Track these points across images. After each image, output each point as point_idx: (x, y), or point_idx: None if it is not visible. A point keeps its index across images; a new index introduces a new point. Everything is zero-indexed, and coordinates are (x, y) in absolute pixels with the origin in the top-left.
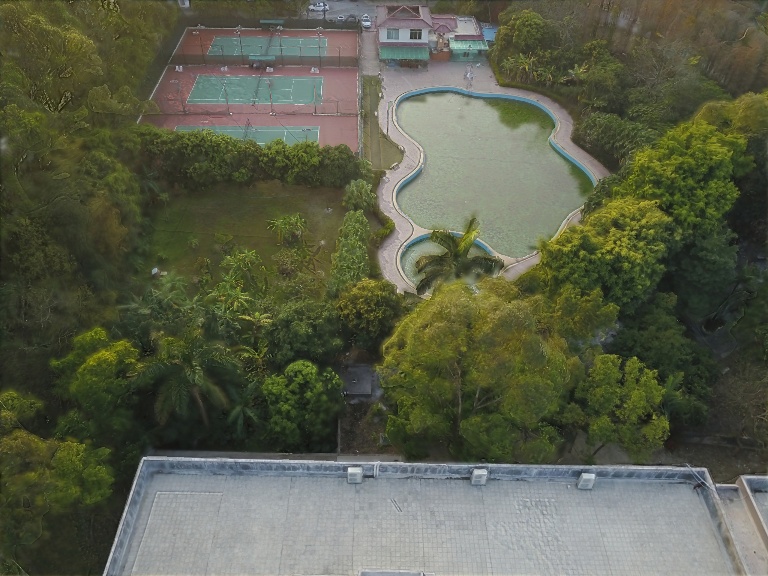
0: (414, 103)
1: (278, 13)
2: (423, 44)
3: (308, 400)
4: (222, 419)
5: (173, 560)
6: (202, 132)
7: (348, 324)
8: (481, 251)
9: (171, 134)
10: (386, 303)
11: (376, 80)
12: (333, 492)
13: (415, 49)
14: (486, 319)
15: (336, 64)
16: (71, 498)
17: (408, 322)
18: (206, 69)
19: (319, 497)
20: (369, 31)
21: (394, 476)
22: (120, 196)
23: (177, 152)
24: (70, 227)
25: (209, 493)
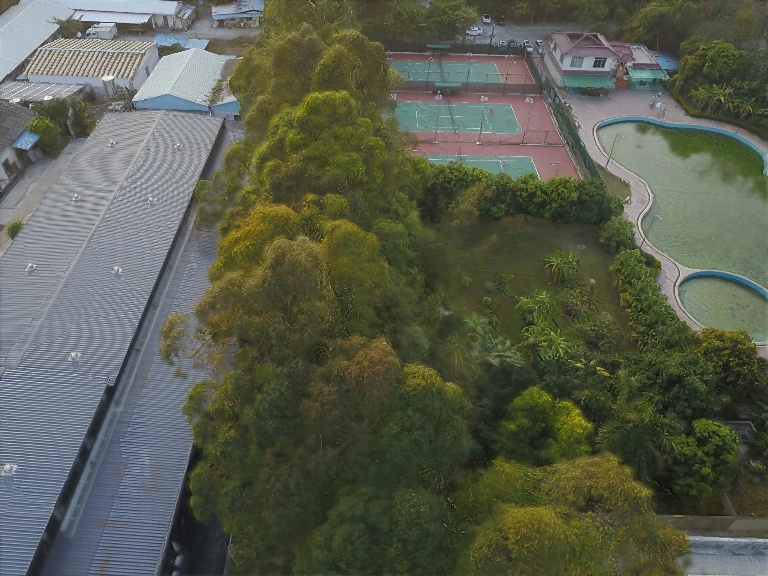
0: (610, 133)
1: None
2: (605, 72)
3: (723, 462)
4: None
5: None
6: None
7: (713, 377)
8: (753, 292)
9: None
10: (753, 355)
11: None
12: None
13: (598, 77)
14: None
15: (520, 91)
16: None
17: None
18: None
19: None
20: (532, 57)
21: None
22: None
23: (440, 186)
24: (446, 274)
25: None
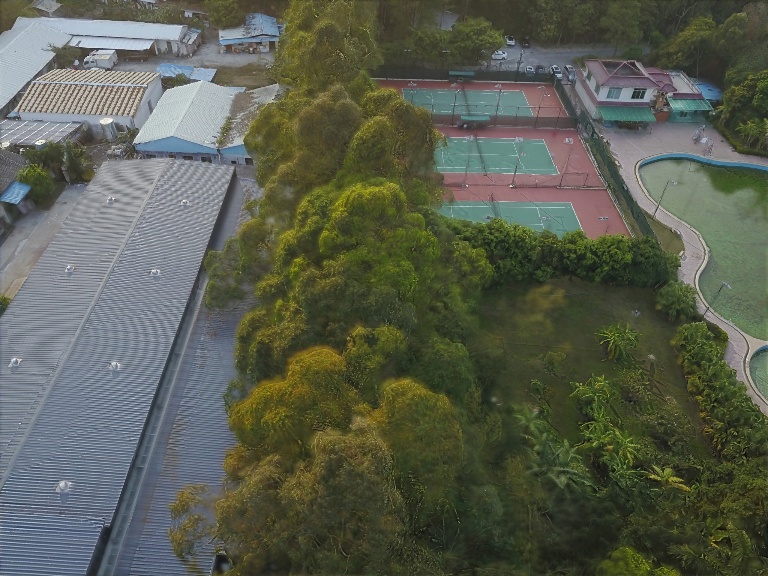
0: (653, 172)
1: None
2: (645, 104)
3: None
4: None
5: None
6: (492, 222)
7: None
8: None
9: (468, 226)
10: None
11: None
12: None
13: (637, 109)
14: None
15: (552, 125)
16: None
17: None
18: None
19: None
20: (562, 84)
21: None
22: None
23: None
24: (506, 387)
25: None
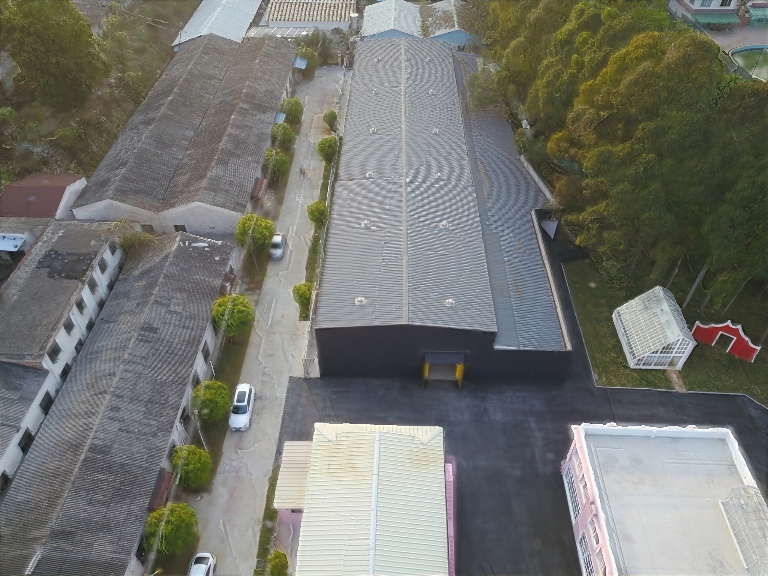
0: (743, 57)
1: None
2: (731, 10)
3: None
4: None
5: None
6: None
7: None
8: None
9: None
10: None
11: None
12: None
13: (725, 15)
14: None
15: None
16: None
17: None
18: None
19: None
20: None
21: None
22: None
23: None
24: None
25: None
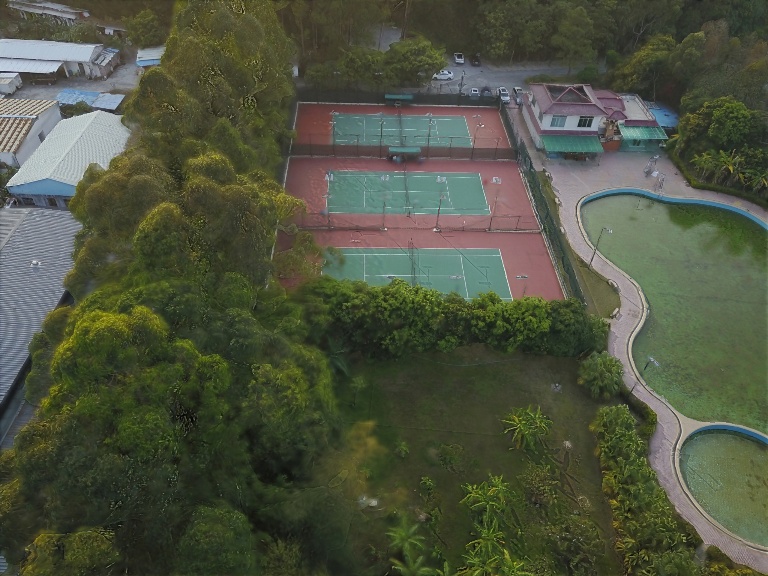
0: (597, 211)
1: (400, 84)
2: (592, 133)
3: None
4: None
5: None
6: (392, 283)
7: None
8: None
9: (359, 291)
10: None
11: (543, 178)
12: None
13: (584, 139)
14: None
15: (491, 156)
16: None
17: None
18: (337, 162)
19: None
20: (509, 108)
21: None
22: (330, 411)
23: (371, 318)
24: (333, 538)
25: None
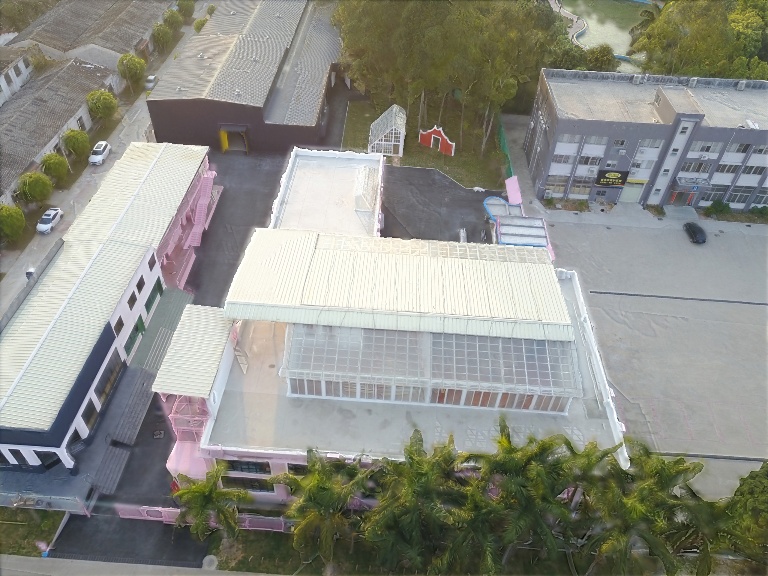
0: None
1: None
2: None
3: None
4: (532, 101)
5: (569, 96)
6: None
7: None
8: None
9: None
10: None
11: None
12: (627, 86)
13: None
14: (704, 2)
15: None
16: (502, 92)
17: (653, 25)
18: None
19: (622, 87)
20: None
21: (652, 84)
22: None
23: None
24: None
25: (572, 83)
